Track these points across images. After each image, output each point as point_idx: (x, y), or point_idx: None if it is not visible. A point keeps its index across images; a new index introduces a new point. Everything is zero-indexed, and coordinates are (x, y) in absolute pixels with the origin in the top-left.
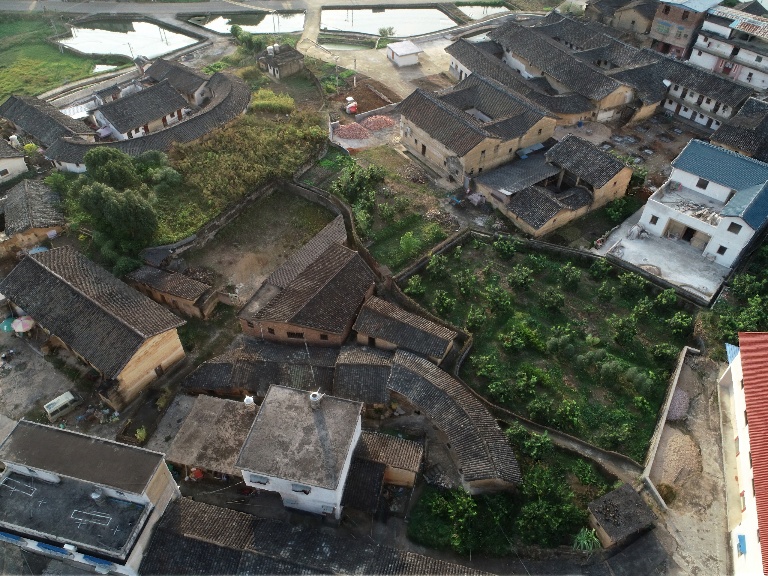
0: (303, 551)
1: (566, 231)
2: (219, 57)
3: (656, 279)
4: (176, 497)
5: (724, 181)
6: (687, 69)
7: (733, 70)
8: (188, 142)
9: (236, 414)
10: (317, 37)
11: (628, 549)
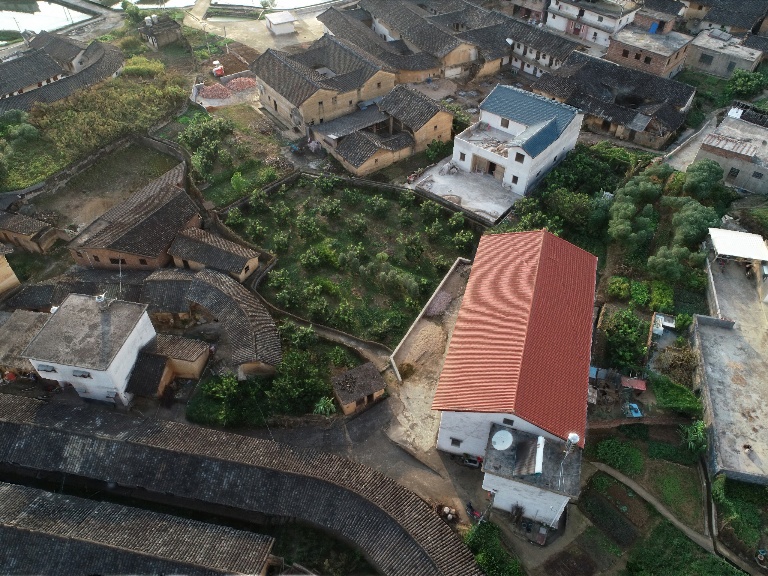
0: (76, 423)
1: (389, 171)
2: (109, 31)
3: (454, 206)
4: None
5: (520, 119)
6: (527, 28)
7: (581, 31)
8: (51, 102)
9: None
10: (206, 11)
11: (364, 414)
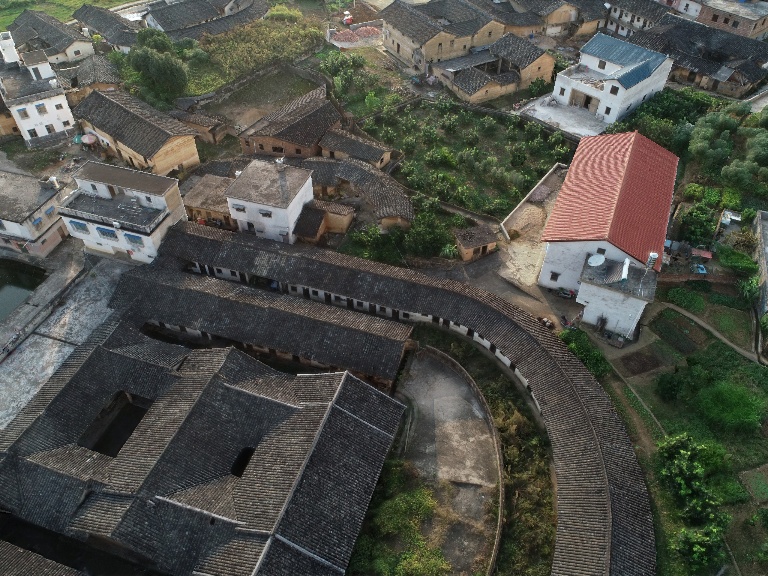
0: (262, 245)
1: (496, 102)
2: None
3: (553, 129)
4: (185, 221)
5: (616, 60)
6: None
7: (674, 2)
8: (215, 35)
9: None
10: None
11: (479, 261)
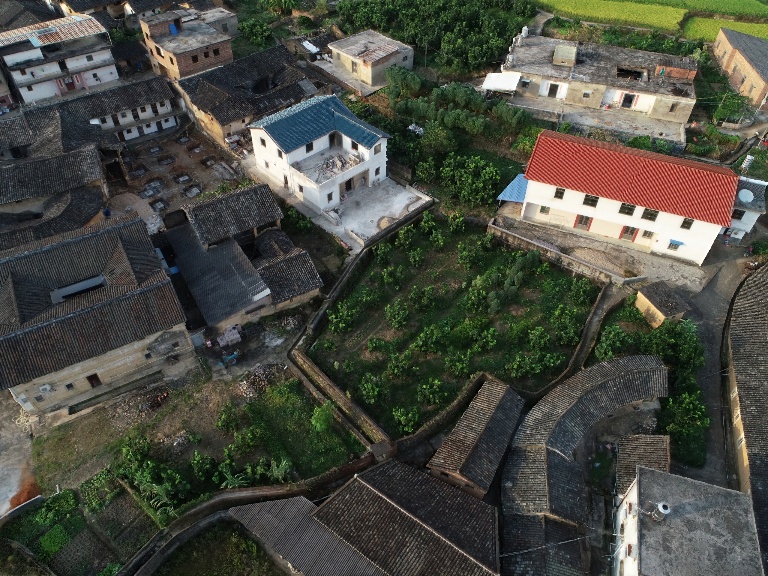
0: None
1: None
2: None
3: (401, 221)
4: None
5: (321, 132)
6: (92, 99)
7: (76, 82)
8: None
9: None
10: None
11: None
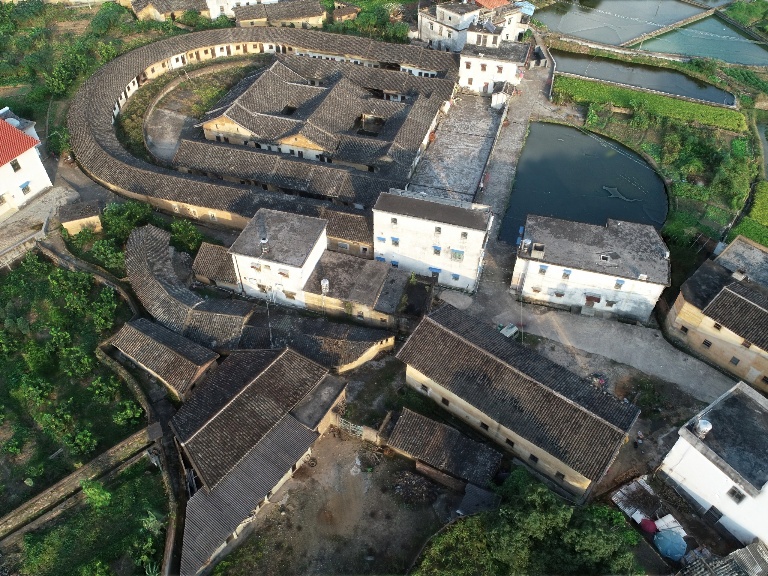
0: (289, 210)
1: None
2: None
3: None
4: None
5: None
6: None
7: None
8: None
9: (338, 289)
10: None
11: None
